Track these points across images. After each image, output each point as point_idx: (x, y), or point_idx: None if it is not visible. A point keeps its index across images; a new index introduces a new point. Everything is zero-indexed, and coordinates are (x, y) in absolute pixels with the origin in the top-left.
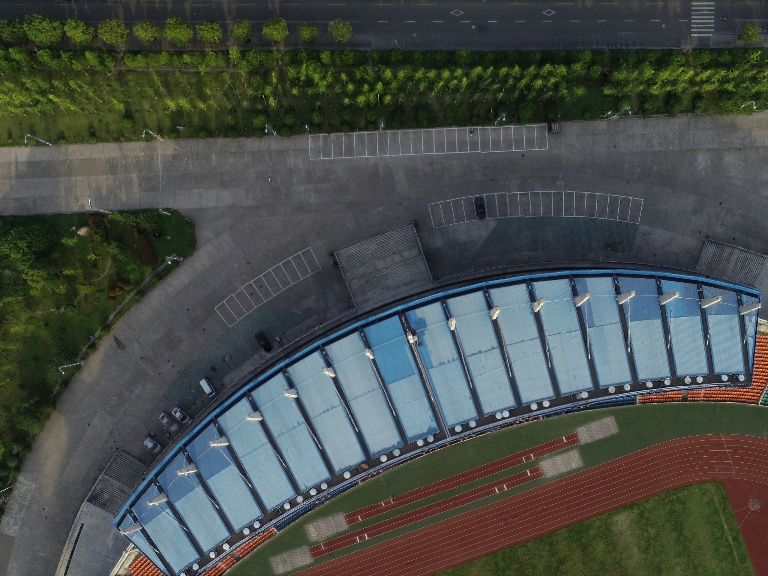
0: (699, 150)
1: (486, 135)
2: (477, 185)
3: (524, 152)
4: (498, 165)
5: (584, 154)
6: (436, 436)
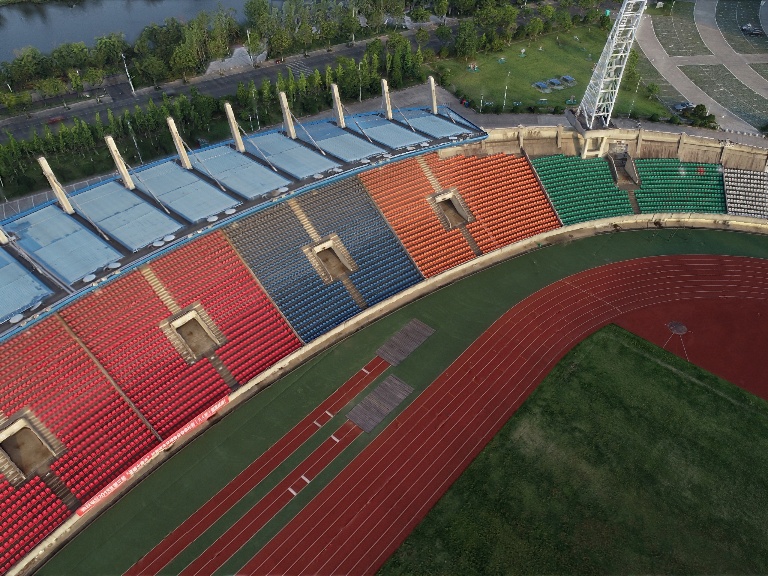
0: None
1: None
2: None
3: None
4: None
5: None
6: (48, 301)
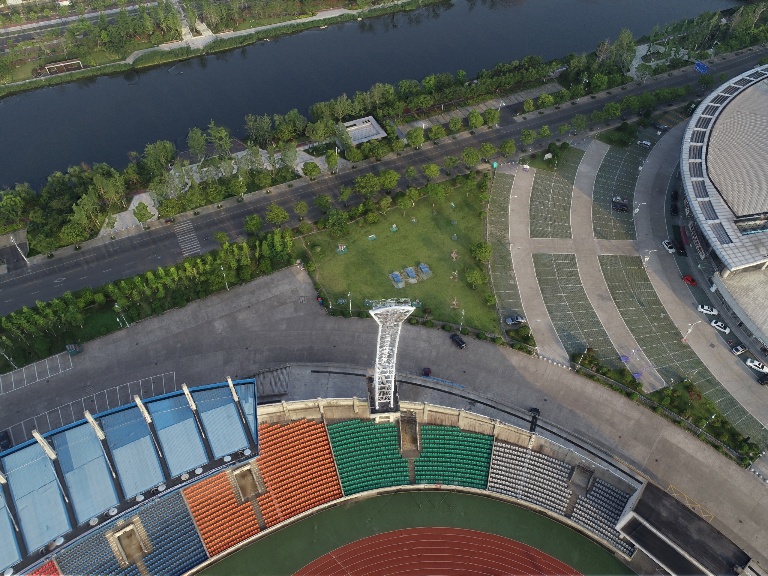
0: (214, 320)
1: (8, 379)
2: (1, 422)
3: (49, 378)
4: (22, 398)
5: (109, 359)
6: None
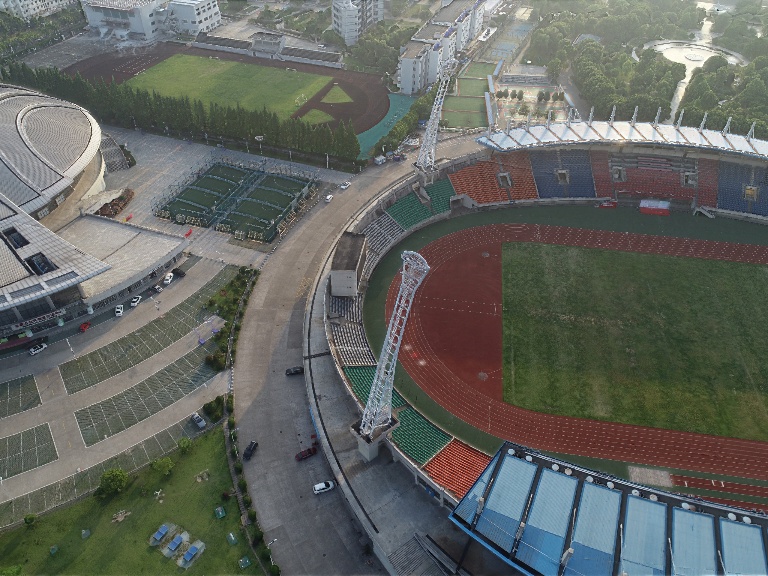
0: None
1: None
2: None
3: None
4: None
5: None
6: None
